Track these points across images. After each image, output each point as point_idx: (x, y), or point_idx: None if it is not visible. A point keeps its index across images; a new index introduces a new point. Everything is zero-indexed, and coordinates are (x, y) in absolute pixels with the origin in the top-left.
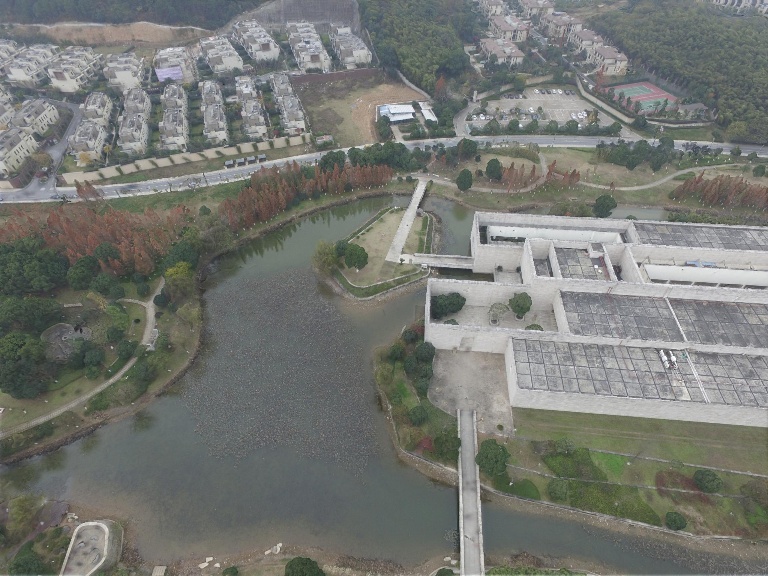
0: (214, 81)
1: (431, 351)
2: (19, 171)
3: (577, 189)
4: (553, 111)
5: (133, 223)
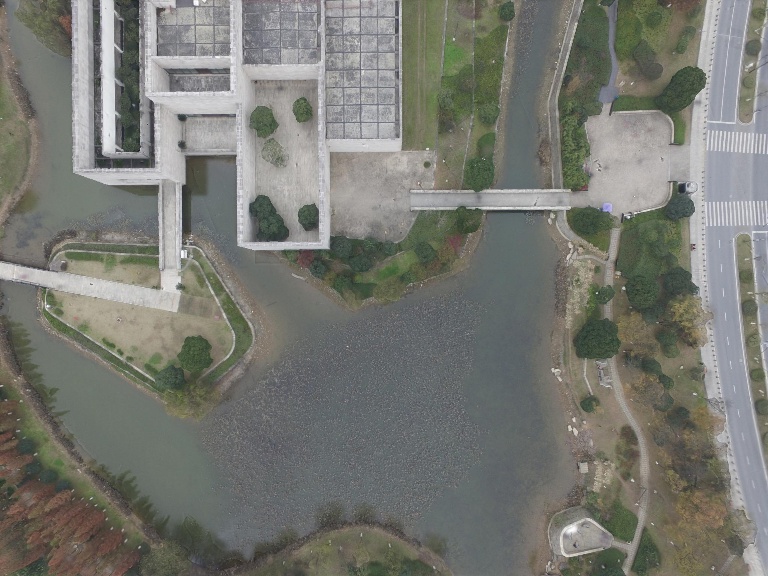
0: None
1: (345, 240)
2: None
3: None
4: None
5: None
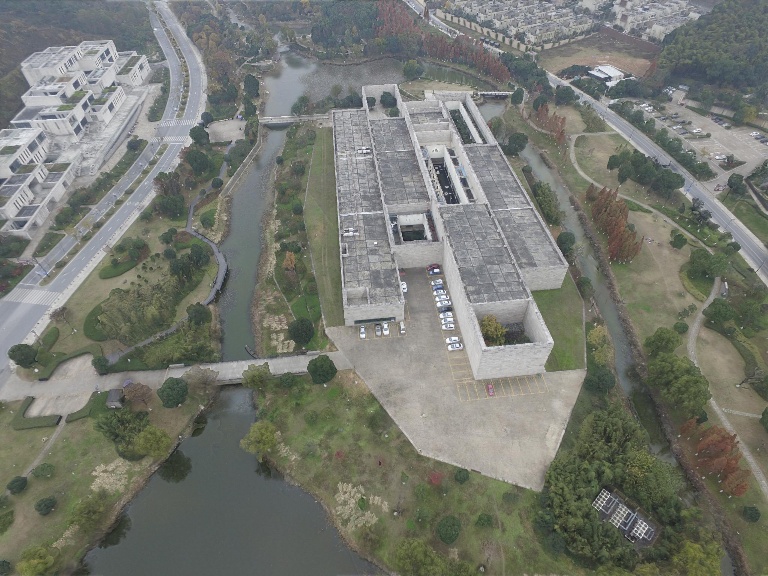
0: (554, 5)
1: (356, 100)
2: (433, 2)
3: (560, 151)
4: (714, 143)
5: (405, 25)
